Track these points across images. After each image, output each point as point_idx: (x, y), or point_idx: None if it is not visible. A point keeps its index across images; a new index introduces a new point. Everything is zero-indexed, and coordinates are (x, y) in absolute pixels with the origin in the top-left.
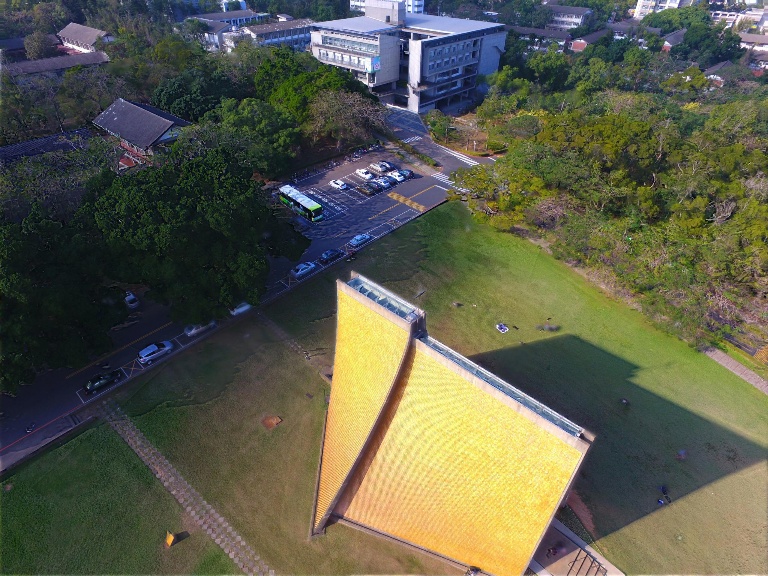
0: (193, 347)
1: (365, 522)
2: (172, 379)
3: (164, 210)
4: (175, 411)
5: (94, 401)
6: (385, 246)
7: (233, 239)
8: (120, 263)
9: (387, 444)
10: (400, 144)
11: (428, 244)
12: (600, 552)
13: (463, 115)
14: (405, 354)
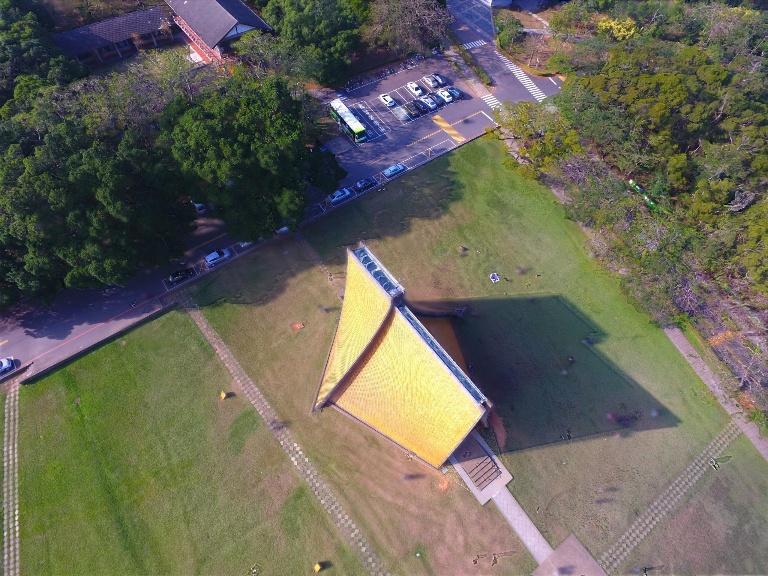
0: (245, 257)
1: (349, 410)
2: (229, 281)
3: (225, 148)
4: (230, 307)
5: (175, 290)
6: (415, 179)
7: (279, 175)
8: (191, 188)
9: (369, 367)
10: (460, 50)
11: (455, 182)
12: (502, 461)
13: (542, 11)
14: (387, 315)
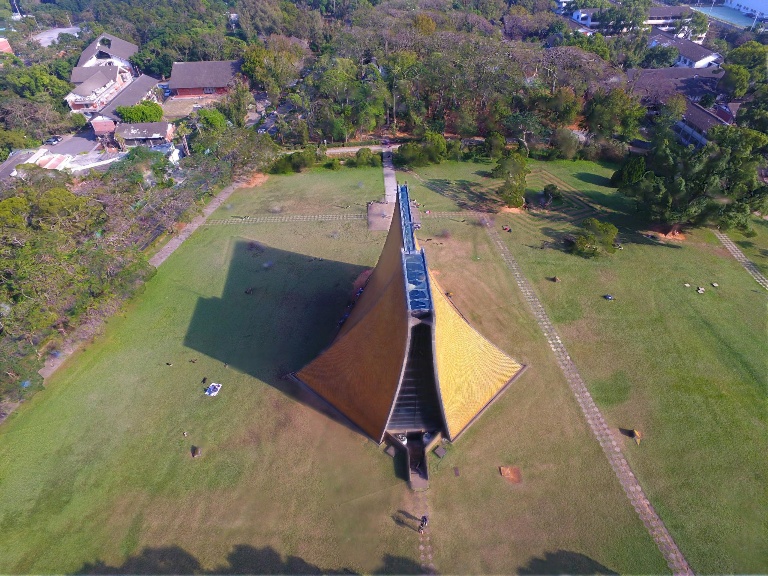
0: None
1: None
2: None
3: None
4: (623, 570)
5: None
6: None
7: None
8: None
9: None
10: None
11: None
12: None
13: None
14: None
